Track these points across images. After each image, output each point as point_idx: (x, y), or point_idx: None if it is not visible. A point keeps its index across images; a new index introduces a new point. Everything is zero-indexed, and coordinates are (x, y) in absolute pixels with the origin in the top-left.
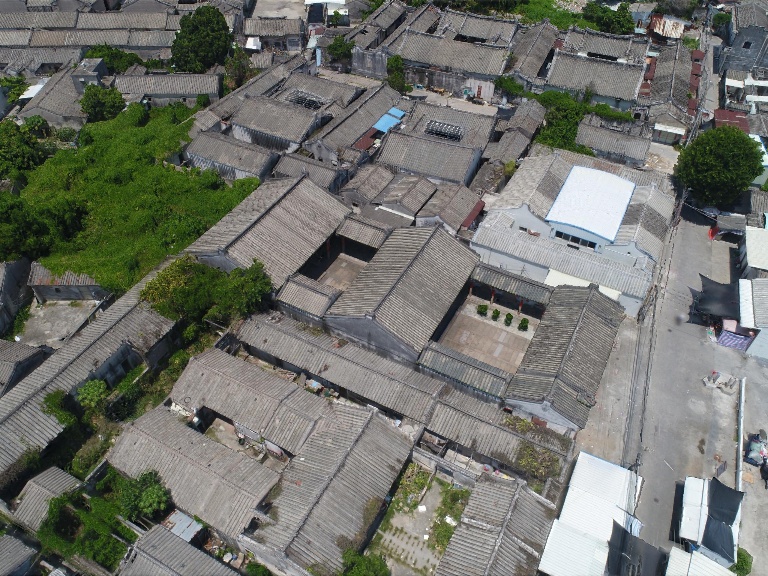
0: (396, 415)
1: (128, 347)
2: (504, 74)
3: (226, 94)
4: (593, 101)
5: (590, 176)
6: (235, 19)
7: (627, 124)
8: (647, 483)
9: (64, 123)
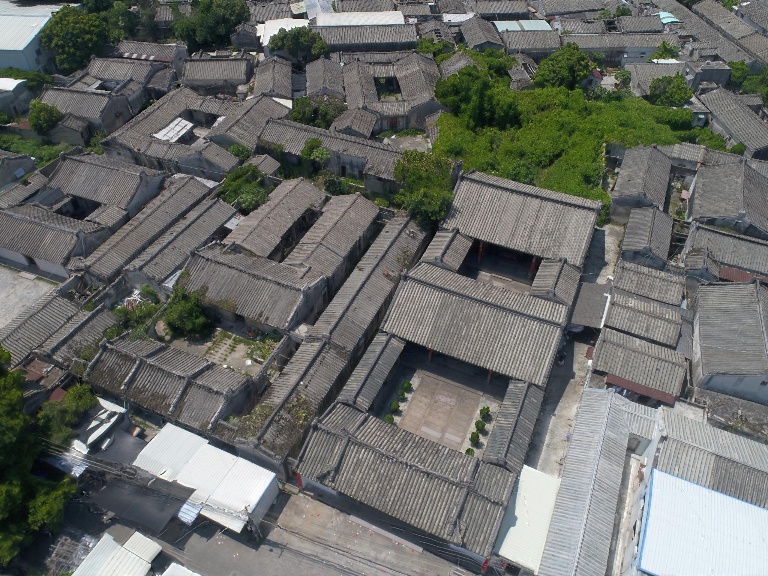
0: None
1: None
2: None
3: None
4: None
5: None
6: None
7: None
8: (256, 570)
9: (636, 89)
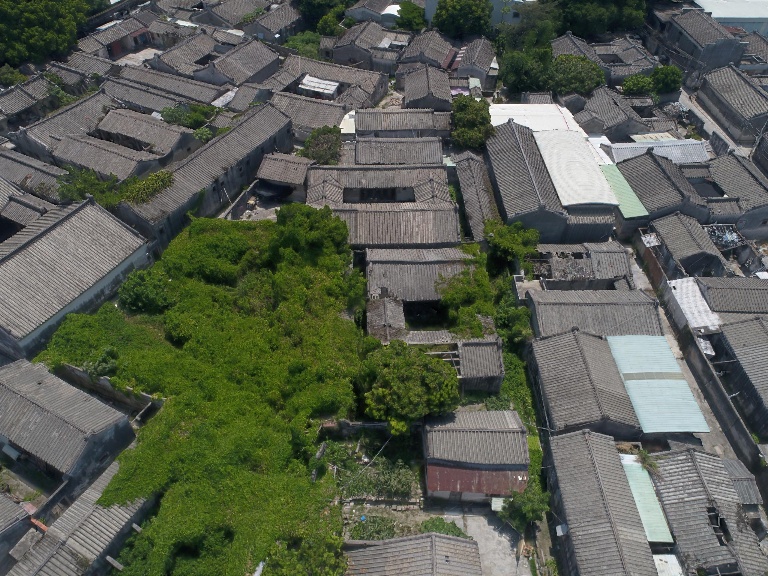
0: None
1: None
2: None
3: None
4: None
5: None
6: None
7: None
8: None
9: None
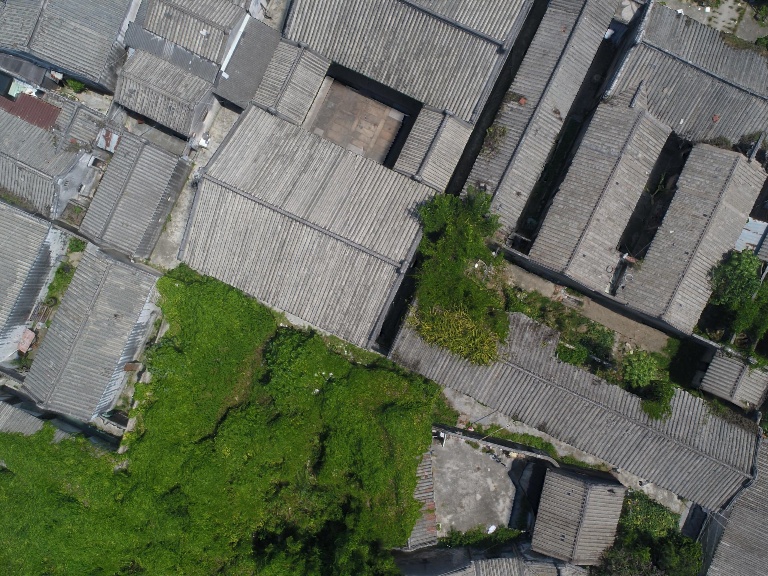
0: None
1: None
2: None
3: None
4: None
5: None
6: None
7: None
8: None
9: None
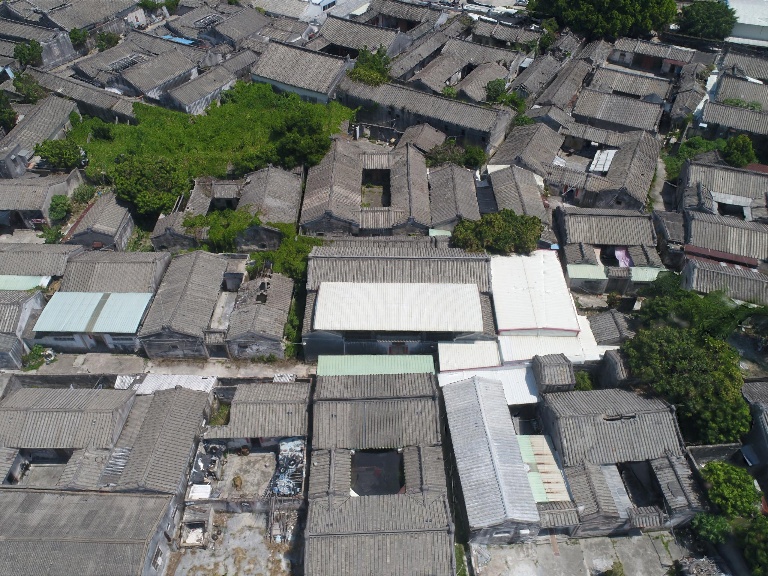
0: (437, 55)
1: None
2: (138, 1)
3: None
4: None
5: None
6: None
7: None
8: None
9: (68, 189)
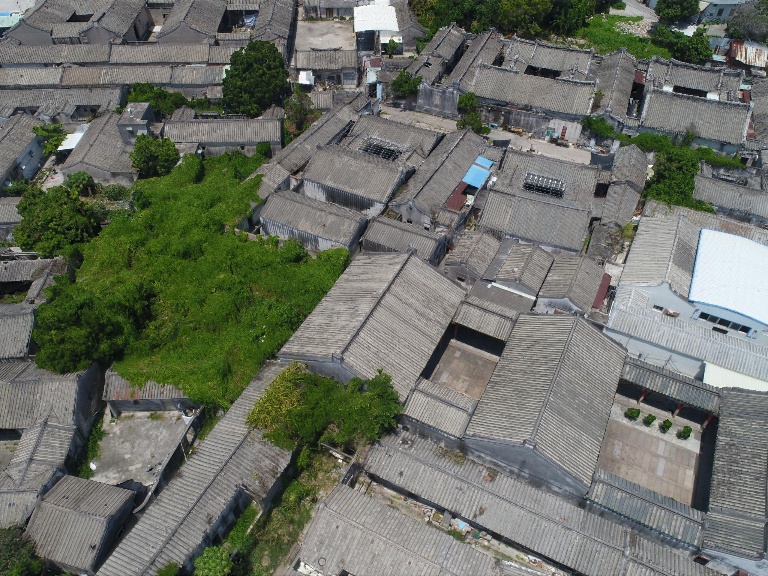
0: (569, 568)
1: (241, 490)
2: (592, 114)
3: (287, 140)
4: (694, 144)
5: (725, 242)
6: (283, 50)
7: (736, 171)
8: None
9: (112, 179)
